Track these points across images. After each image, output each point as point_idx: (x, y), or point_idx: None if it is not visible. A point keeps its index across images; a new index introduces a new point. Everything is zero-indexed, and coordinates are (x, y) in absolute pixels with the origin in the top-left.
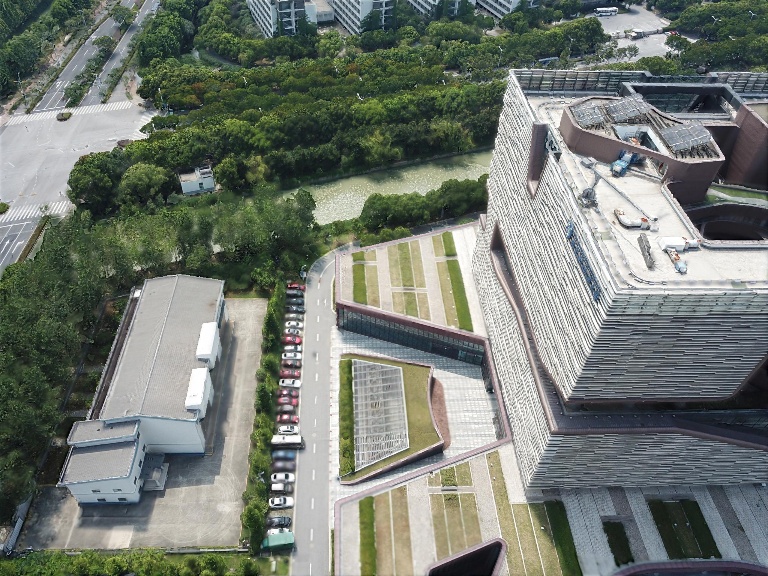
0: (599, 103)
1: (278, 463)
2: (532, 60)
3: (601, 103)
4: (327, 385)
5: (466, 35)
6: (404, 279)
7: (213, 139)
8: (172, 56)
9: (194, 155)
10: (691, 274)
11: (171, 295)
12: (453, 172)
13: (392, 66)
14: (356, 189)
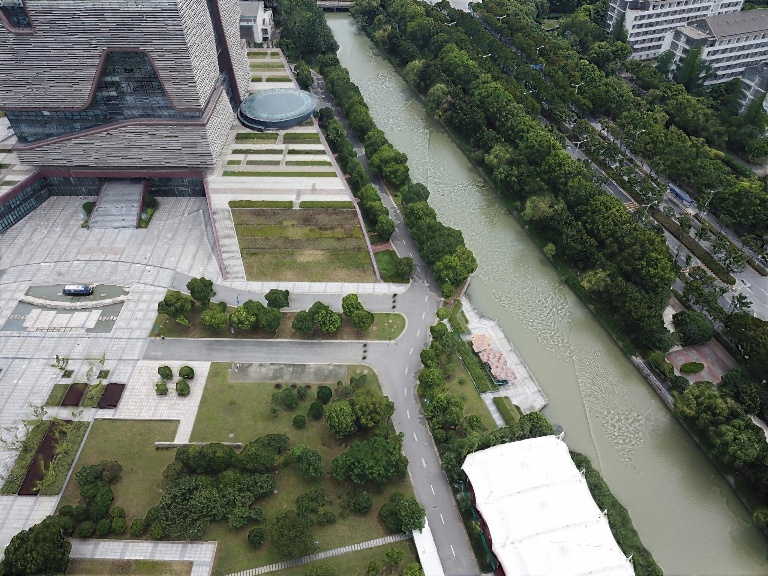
0: None
1: None
2: (661, 175)
3: None
4: None
5: (694, 125)
6: (250, 65)
7: (402, 8)
8: (556, 2)
9: (396, 13)
10: None
11: (246, 3)
12: (413, 121)
13: (561, 72)
14: (393, 86)
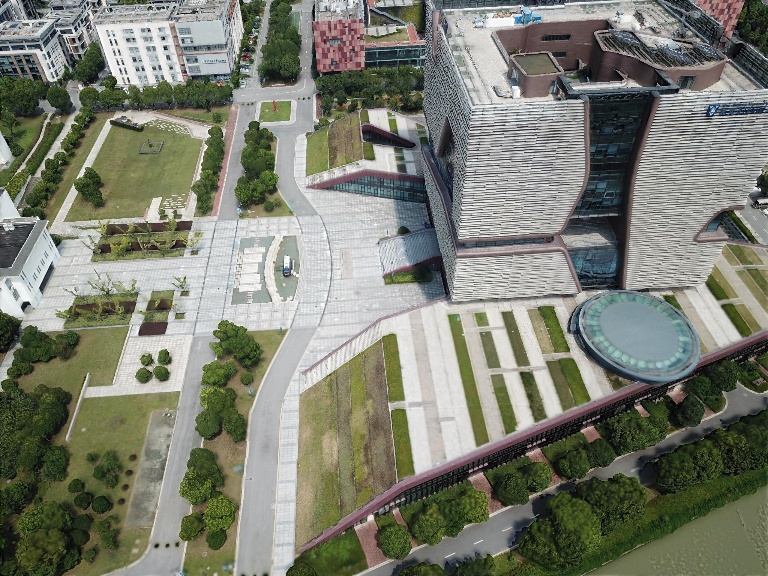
0: (697, 67)
1: (762, 194)
2: None
3: (695, 67)
4: (765, 240)
5: None
6: (761, 276)
7: None
8: None
9: None
10: (613, 13)
11: None
12: None
13: None
14: None
